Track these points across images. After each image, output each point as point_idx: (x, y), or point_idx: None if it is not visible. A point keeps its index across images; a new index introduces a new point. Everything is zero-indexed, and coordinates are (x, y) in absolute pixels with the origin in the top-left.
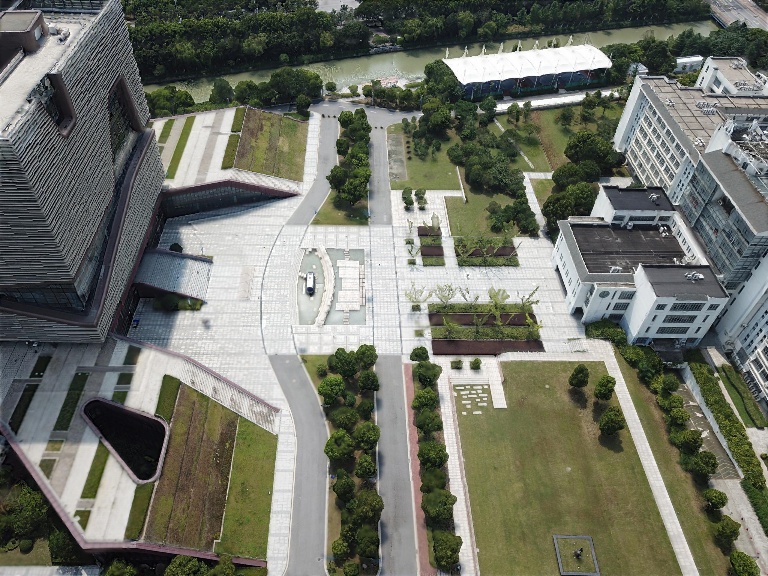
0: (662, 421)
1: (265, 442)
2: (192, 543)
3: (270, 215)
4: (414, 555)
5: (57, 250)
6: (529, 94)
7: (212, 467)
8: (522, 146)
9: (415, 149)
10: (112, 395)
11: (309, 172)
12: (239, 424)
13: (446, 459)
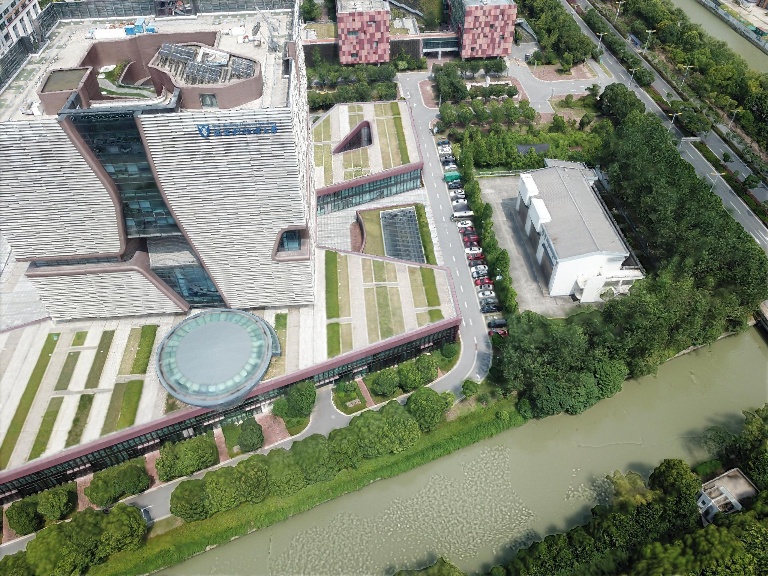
0: None
1: None
2: None
3: None
4: None
5: None
6: None
7: None
8: None
9: None
10: None
11: None
12: None
13: None
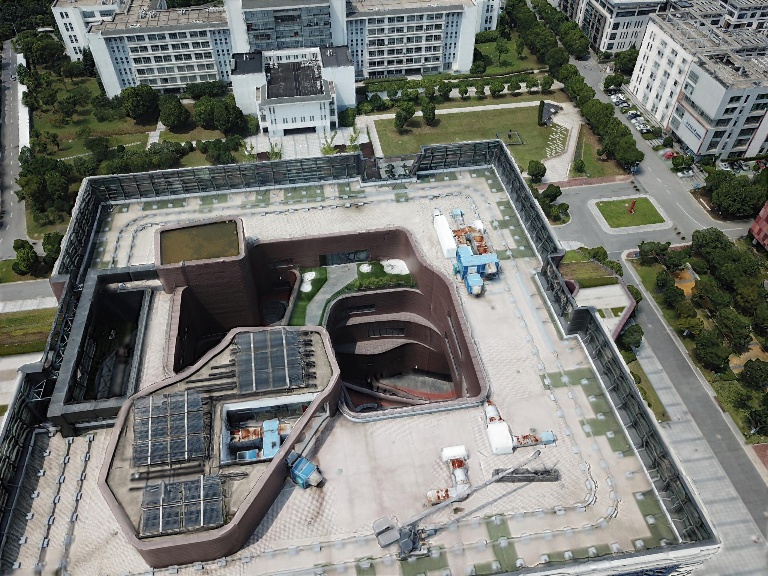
0: None
1: None
2: (594, 265)
3: None
4: None
5: None
6: None
7: None
8: None
9: None
10: None
11: None
12: None
13: None
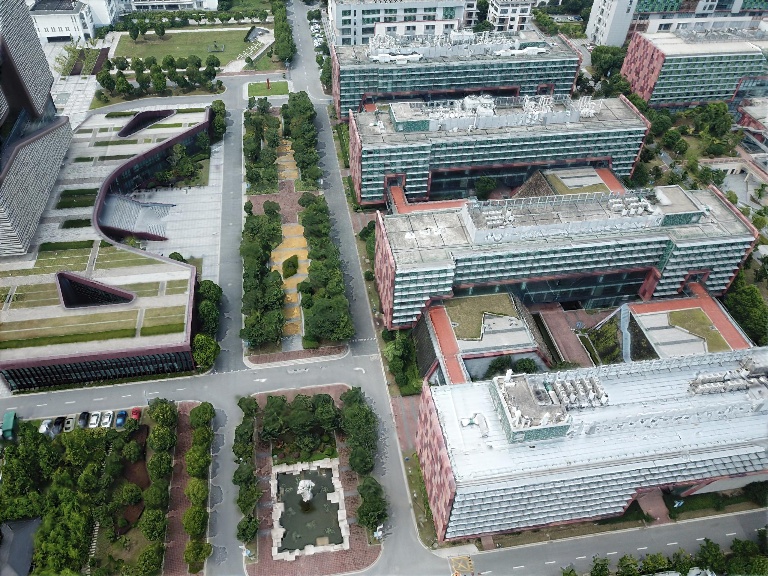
0: None
1: None
2: None
3: None
4: None
5: None
6: None
7: None
8: None
9: None
10: (115, 131)
11: None
12: None
13: None
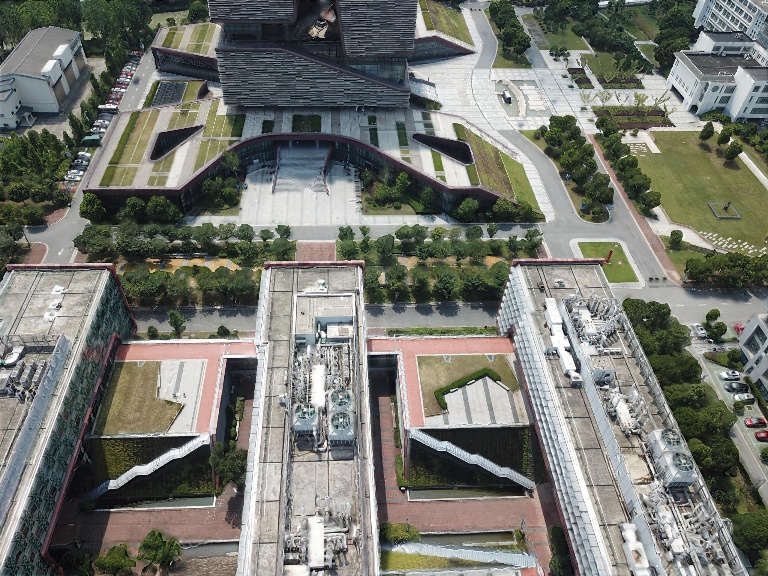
0: (761, 158)
1: (517, 165)
2: None
3: (461, 63)
4: (628, 211)
5: (414, 25)
6: None
7: (497, 168)
8: (624, 27)
9: (548, 27)
10: (425, 132)
11: (477, 41)
12: (501, 154)
13: (637, 165)
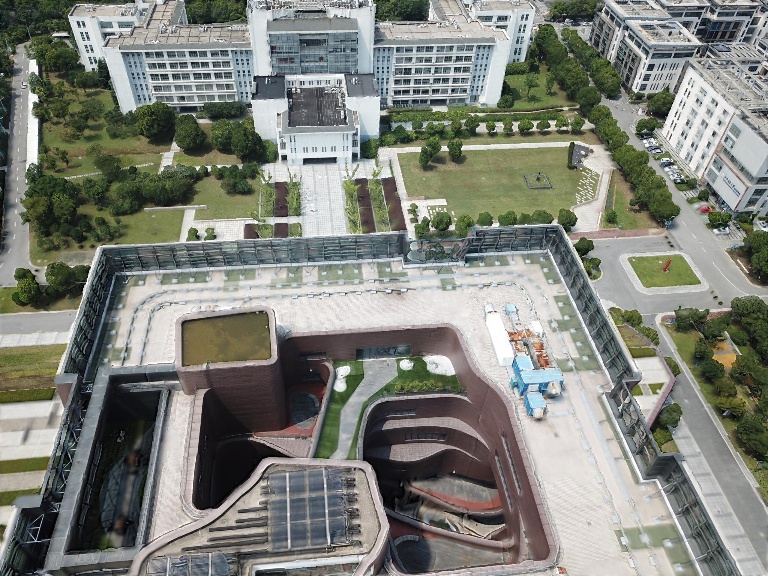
0: None
1: None
2: (628, 331)
3: None
4: None
5: None
6: (5, 152)
7: None
8: None
9: None
10: None
11: None
12: None
13: None
